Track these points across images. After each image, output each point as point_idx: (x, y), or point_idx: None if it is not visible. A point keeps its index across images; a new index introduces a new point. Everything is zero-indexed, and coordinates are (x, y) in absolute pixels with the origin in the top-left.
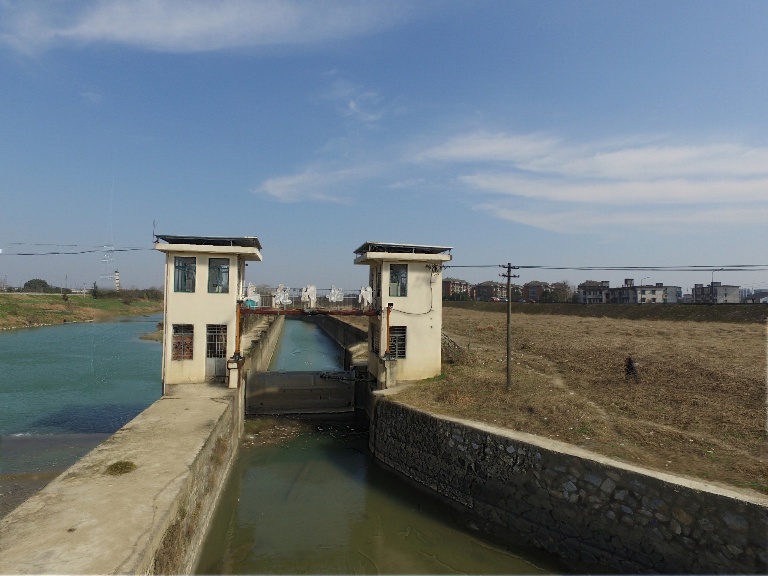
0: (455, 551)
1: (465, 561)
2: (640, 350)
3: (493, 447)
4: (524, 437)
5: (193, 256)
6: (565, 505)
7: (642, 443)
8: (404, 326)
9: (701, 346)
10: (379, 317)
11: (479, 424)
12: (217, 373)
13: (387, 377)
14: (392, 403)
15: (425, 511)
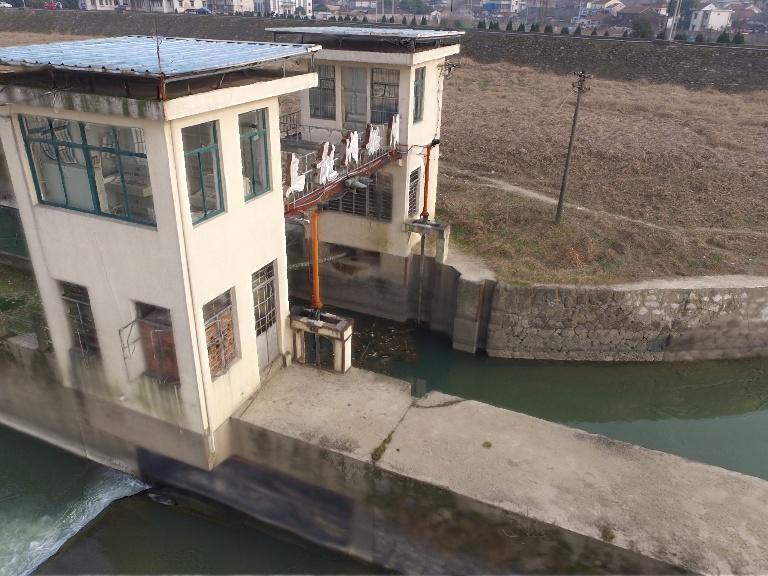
0: (630, 403)
1: (642, 406)
2: (462, 123)
3: (697, 301)
4: (717, 282)
5: (214, 117)
6: (761, 326)
7: (753, 253)
8: (419, 167)
9: (492, 109)
10: (401, 162)
11: (664, 282)
12: (270, 357)
13: None
14: (536, 289)
15: (592, 385)
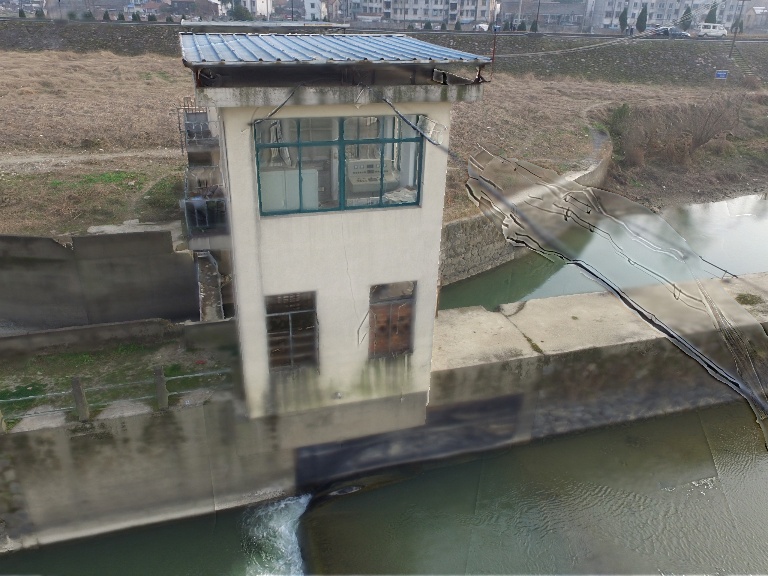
0: None
1: None
2: None
3: None
4: None
5: None
6: None
7: None
8: None
9: None
10: None
11: None
12: None
13: None
14: (449, 227)
15: None
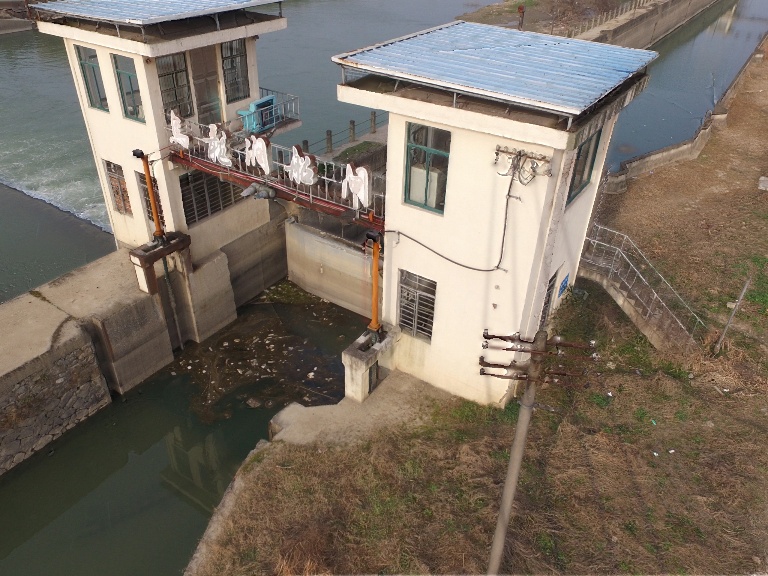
0: None
1: None
2: None
3: None
4: None
5: (92, 46)
6: None
7: None
8: (432, 279)
9: None
10: None
11: None
12: None
13: (346, 380)
14: None
15: None
